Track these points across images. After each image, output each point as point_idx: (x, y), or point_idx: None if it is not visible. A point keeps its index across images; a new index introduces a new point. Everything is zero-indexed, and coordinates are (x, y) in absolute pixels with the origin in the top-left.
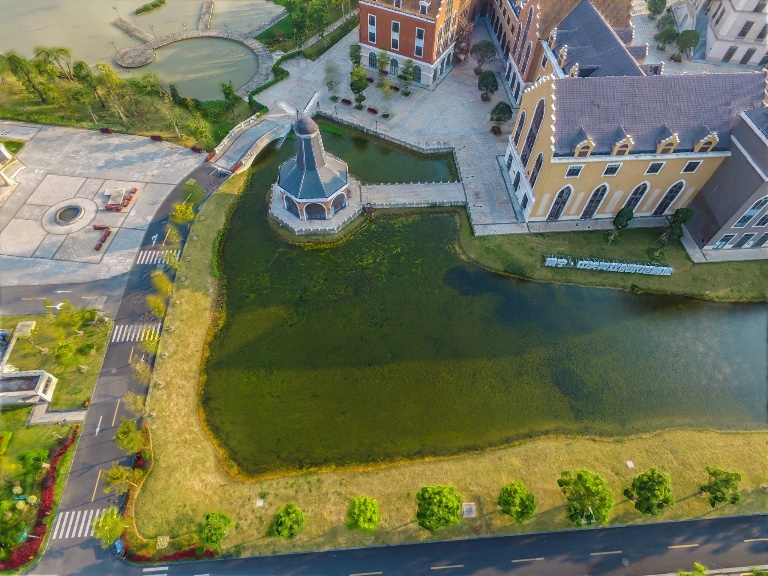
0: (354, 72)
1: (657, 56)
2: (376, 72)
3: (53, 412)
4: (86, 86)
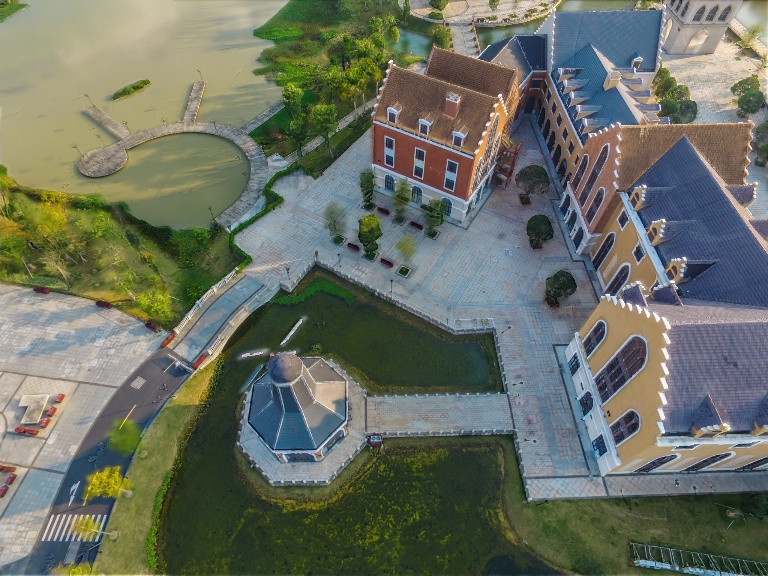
0: (363, 222)
1: (756, 176)
2: (393, 198)
3: None
4: (22, 228)
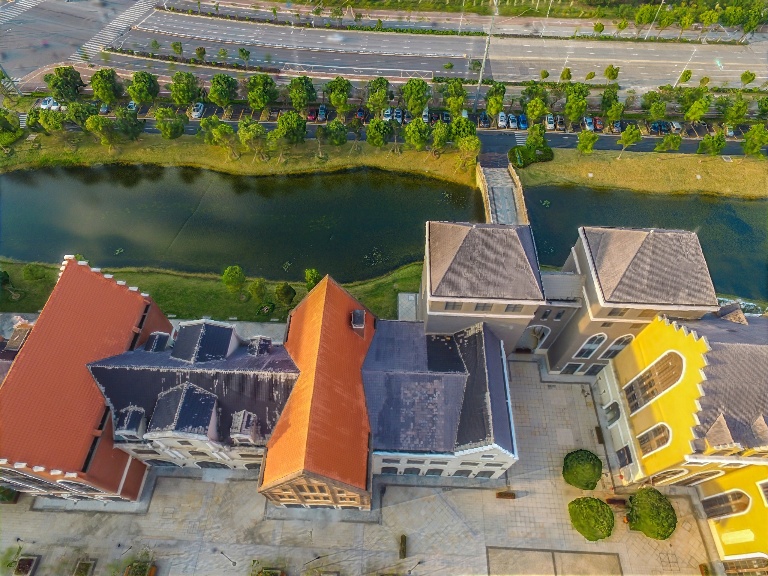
0: None
1: None
2: None
3: None
4: None
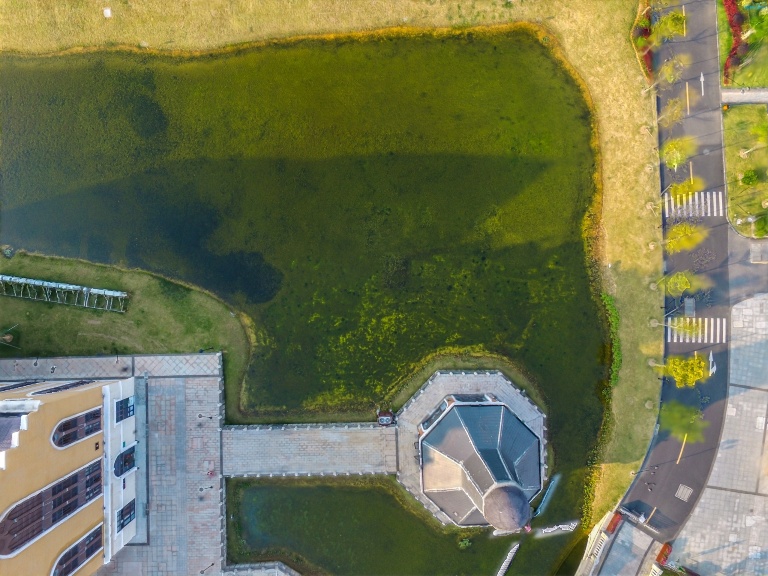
0: None
1: None
2: None
3: (760, 103)
4: None
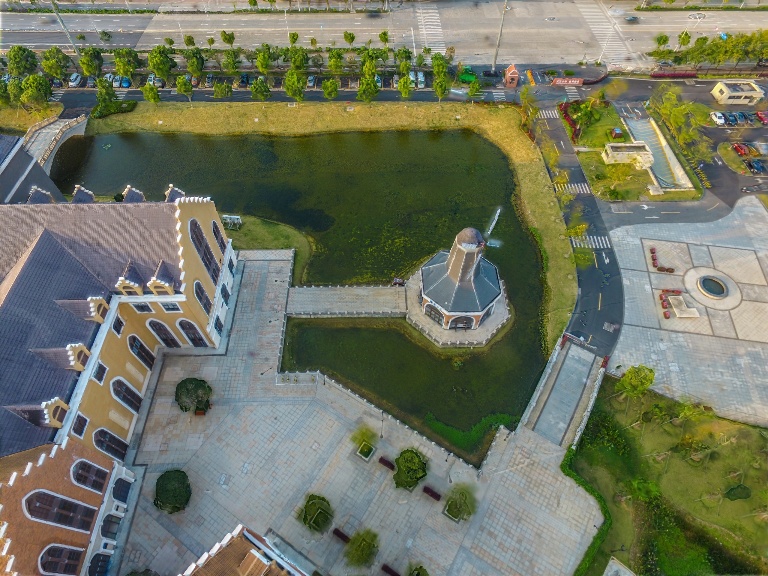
0: None
1: None
2: None
3: None
4: None
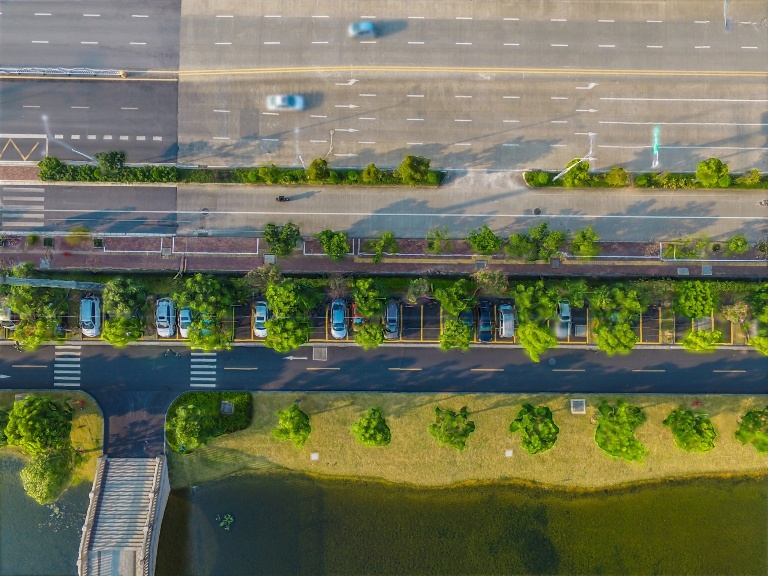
0: None
1: None
2: None
3: None
4: None
